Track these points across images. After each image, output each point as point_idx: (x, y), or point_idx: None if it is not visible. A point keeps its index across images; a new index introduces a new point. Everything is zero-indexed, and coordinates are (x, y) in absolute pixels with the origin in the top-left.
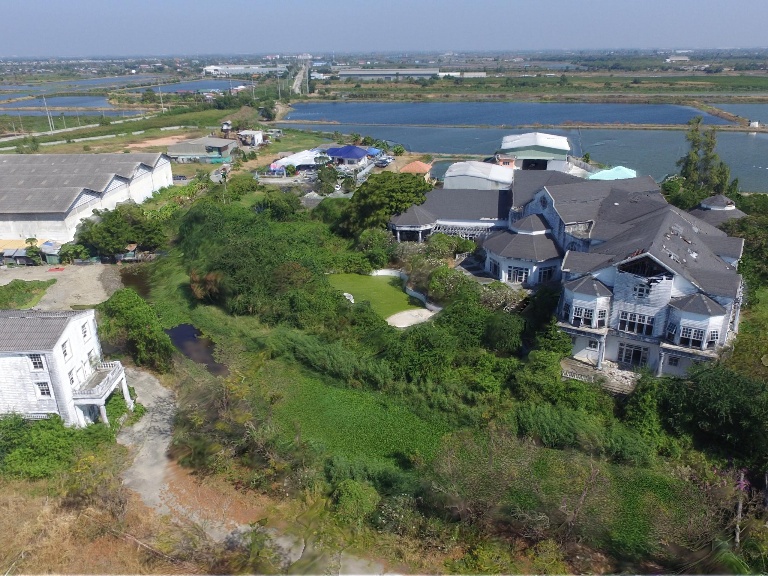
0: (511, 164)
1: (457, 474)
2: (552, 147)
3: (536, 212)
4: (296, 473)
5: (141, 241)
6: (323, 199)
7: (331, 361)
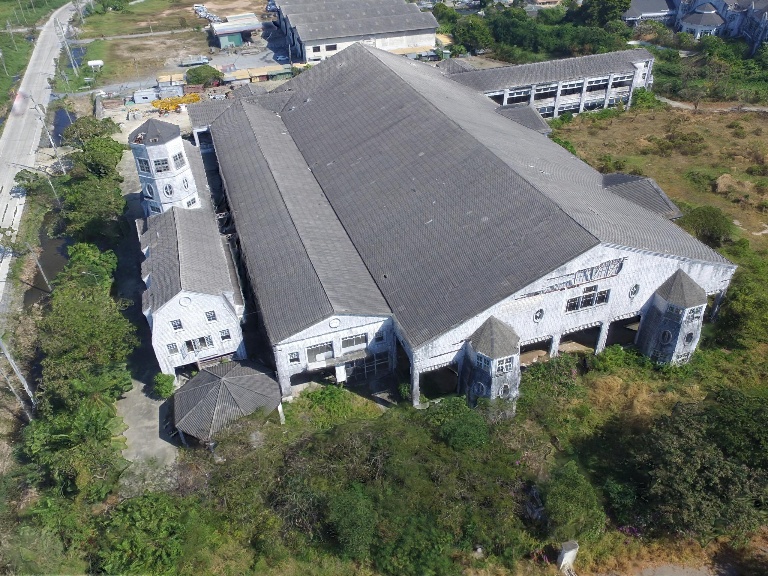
0: None
1: None
2: None
3: (707, 2)
4: None
5: None
6: (538, 10)
7: (682, 70)
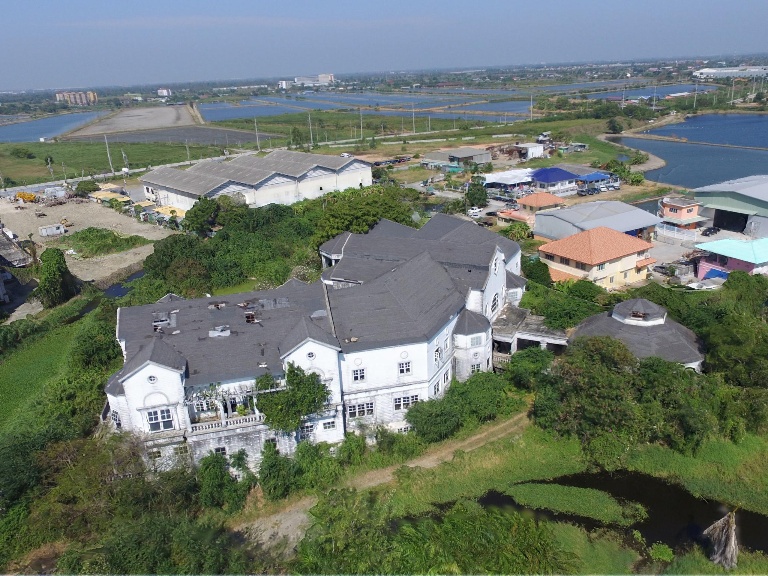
0: (679, 212)
1: None
2: (755, 197)
3: None
4: None
5: None
6: None
7: None
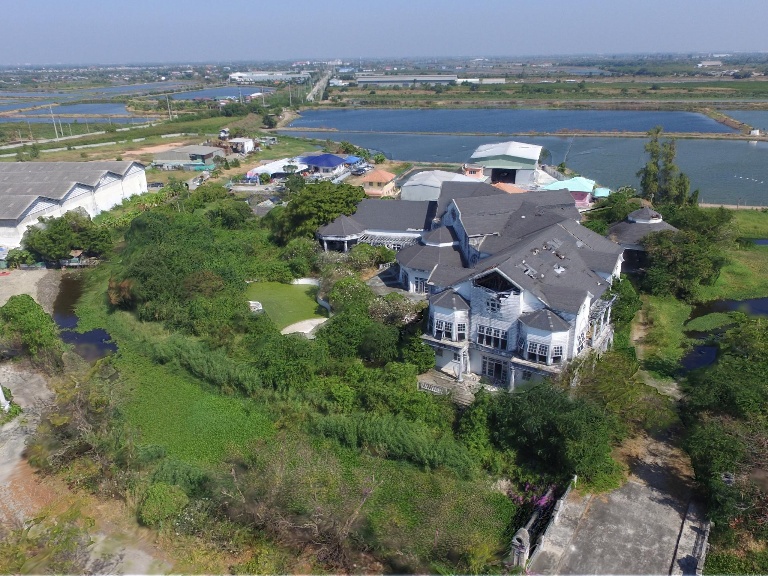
0: (477, 173)
1: (285, 481)
2: (520, 157)
3: (448, 224)
4: (117, 475)
5: (87, 247)
6: (274, 208)
7: (209, 368)
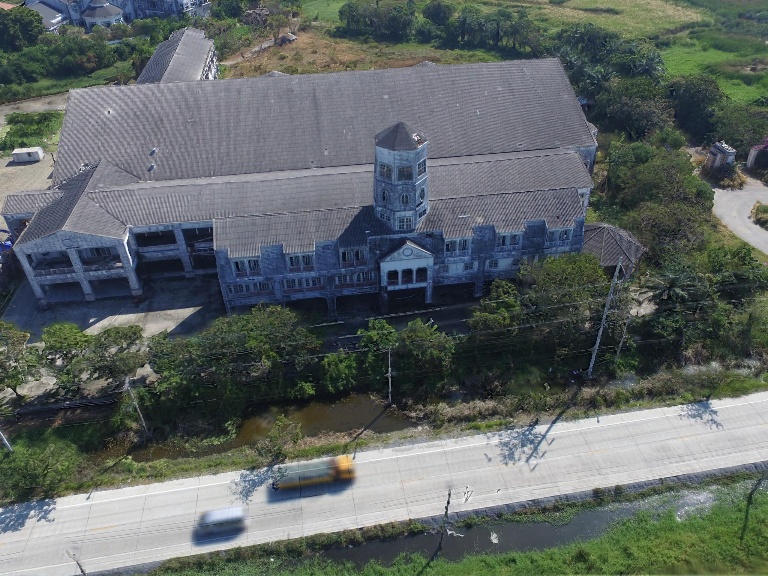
0: None
1: None
2: None
3: None
4: None
5: None
6: None
7: None
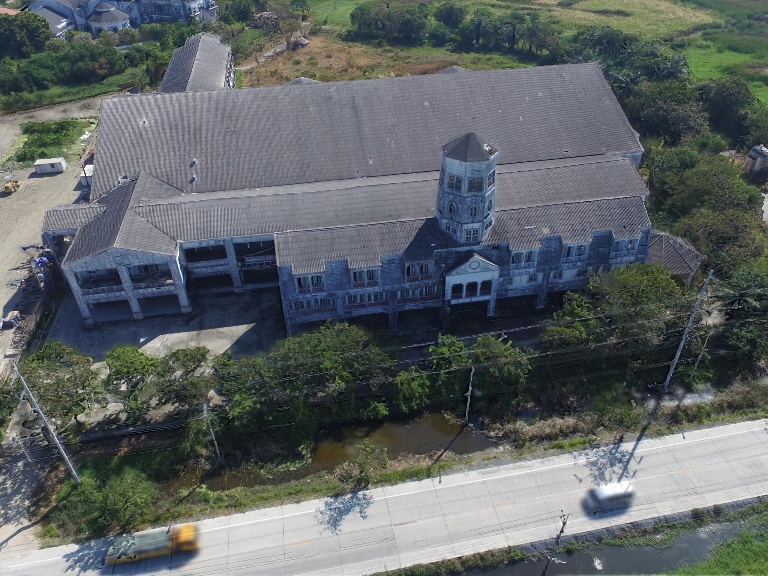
0: None
1: None
2: None
3: (100, 1)
4: None
5: None
6: None
7: None
